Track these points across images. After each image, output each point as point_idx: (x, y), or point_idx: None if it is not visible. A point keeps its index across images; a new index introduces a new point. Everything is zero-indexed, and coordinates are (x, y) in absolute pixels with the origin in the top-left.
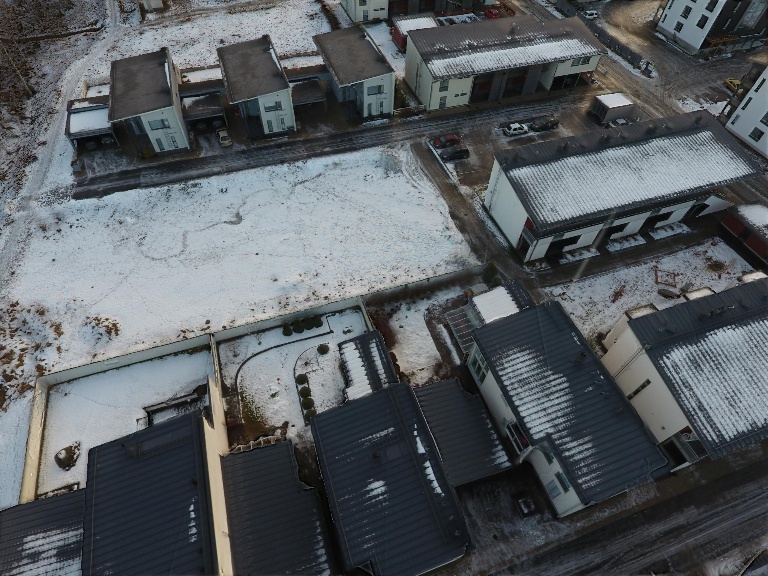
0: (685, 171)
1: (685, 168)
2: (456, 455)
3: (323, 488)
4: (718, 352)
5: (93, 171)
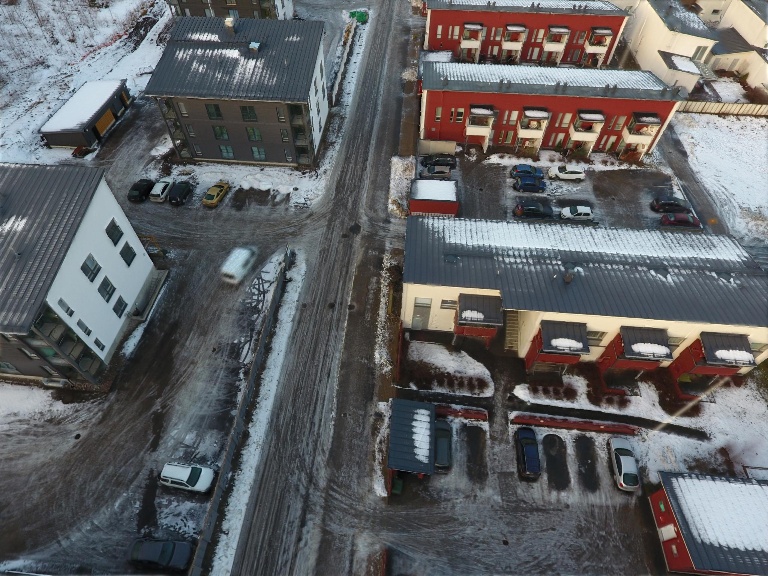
0: (497, 70)
1: (494, 71)
2: (722, 35)
3: None
4: None
5: None
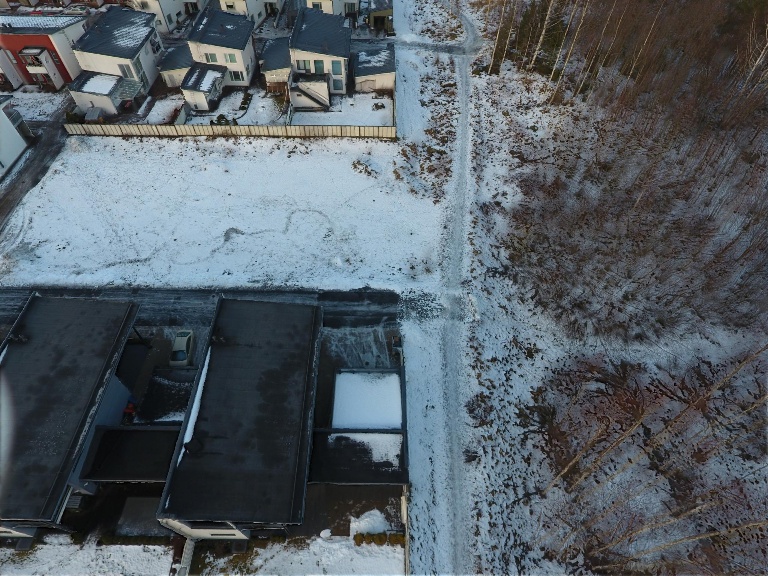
0: None
1: None
2: None
3: (258, 76)
4: (29, 25)
5: (376, 336)
